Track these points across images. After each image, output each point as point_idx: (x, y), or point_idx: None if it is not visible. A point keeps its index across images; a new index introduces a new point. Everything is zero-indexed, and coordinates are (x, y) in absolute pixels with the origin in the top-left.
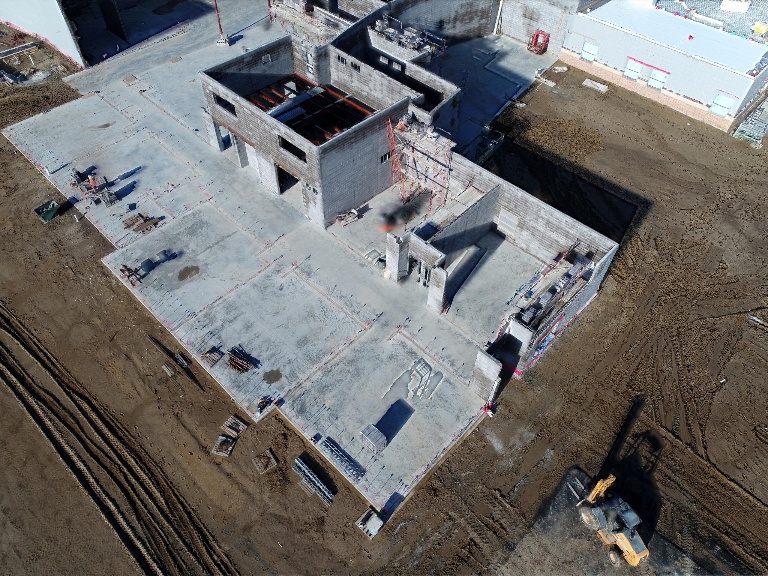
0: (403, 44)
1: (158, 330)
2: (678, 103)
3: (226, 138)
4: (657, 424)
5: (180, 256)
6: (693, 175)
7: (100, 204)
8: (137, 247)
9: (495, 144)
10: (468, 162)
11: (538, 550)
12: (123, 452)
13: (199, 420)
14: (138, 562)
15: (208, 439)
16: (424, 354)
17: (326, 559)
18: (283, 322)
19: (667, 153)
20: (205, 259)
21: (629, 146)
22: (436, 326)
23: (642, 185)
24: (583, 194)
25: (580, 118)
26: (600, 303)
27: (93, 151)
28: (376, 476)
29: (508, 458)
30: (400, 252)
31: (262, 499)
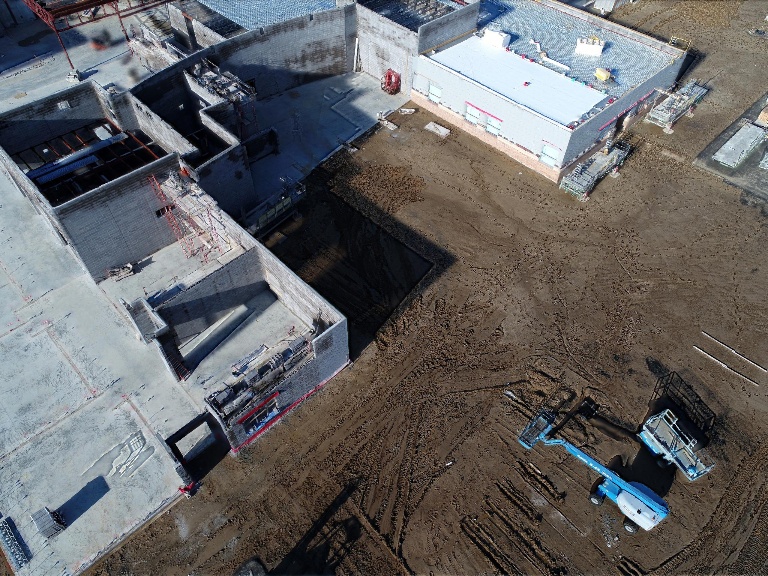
0: (211, 91)
1: None
2: (513, 151)
3: None
4: (360, 512)
5: None
6: (505, 230)
7: None
8: None
9: None
10: (231, 221)
11: None
12: None
13: None
14: None
15: None
16: (144, 426)
17: None
18: (13, 387)
19: (486, 205)
20: None
21: (449, 197)
22: (169, 395)
23: (447, 240)
24: (380, 250)
25: (409, 165)
26: (351, 372)
27: None
28: (41, 563)
29: (188, 546)
30: (135, 317)
31: None
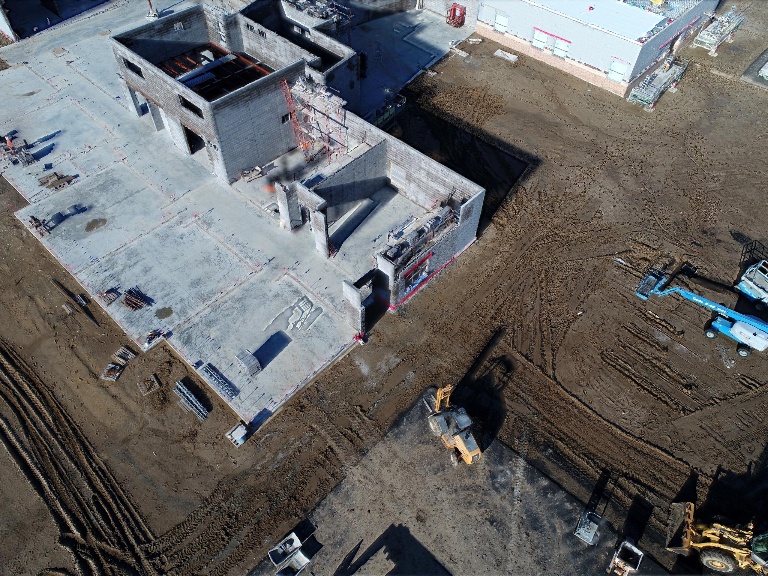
0: (311, 13)
1: (62, 275)
2: (580, 71)
3: (146, 104)
4: (513, 350)
5: (89, 210)
6: (585, 136)
7: (18, 164)
8: (49, 202)
9: (398, 107)
10: (359, 119)
11: (388, 454)
12: (18, 379)
13: (92, 351)
14: (22, 470)
15: (98, 367)
16: (308, 292)
17: (195, 465)
18: (180, 266)
19: (564, 116)
20: (113, 212)
21: (529, 110)
22: (322, 268)
23: (536, 145)
24: (479, 153)
25: (487, 85)
26: (478, 248)
27: (16, 117)
28: (249, 395)
29: (373, 379)
30: (288, 200)
31: (142, 416)
